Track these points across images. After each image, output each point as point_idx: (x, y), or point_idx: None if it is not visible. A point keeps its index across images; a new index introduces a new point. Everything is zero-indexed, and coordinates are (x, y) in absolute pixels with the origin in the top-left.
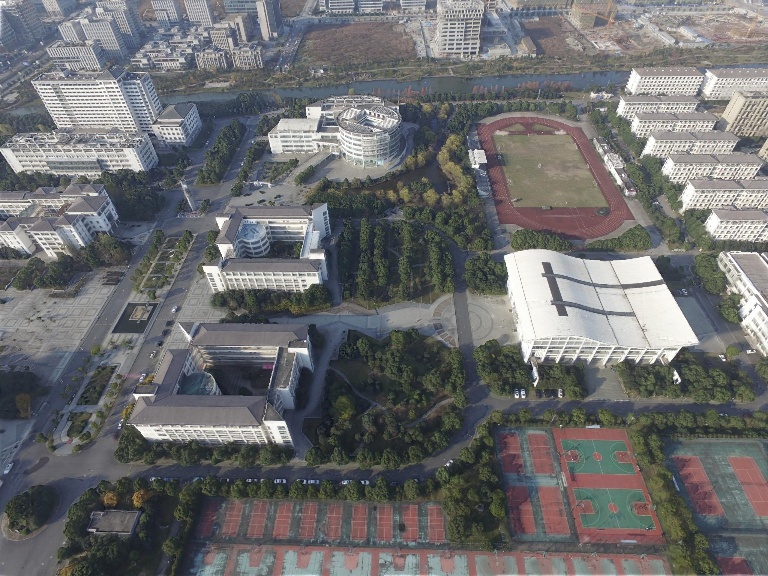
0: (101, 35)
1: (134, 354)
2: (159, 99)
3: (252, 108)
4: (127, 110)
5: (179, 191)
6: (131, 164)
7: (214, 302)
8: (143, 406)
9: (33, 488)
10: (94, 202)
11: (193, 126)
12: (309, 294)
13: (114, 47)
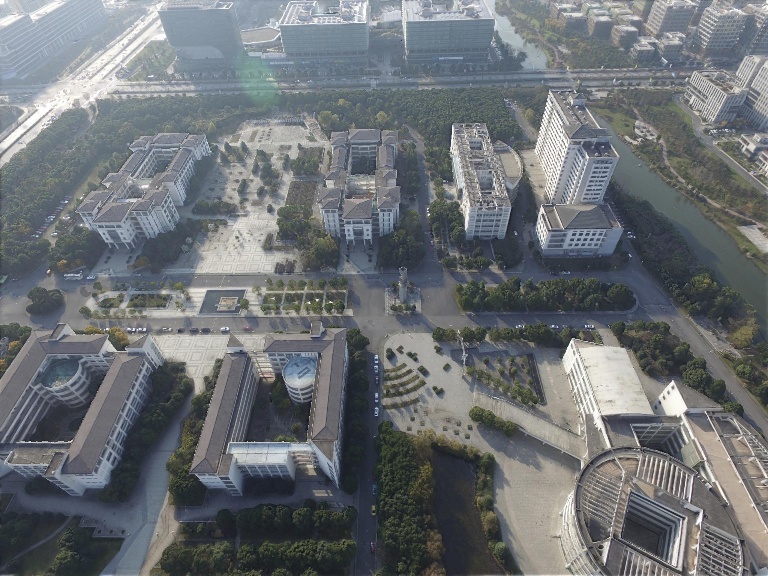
0: (767, 90)
1: (174, 315)
2: (678, 194)
3: (690, 301)
4: (558, 174)
5: (441, 275)
6: (466, 216)
7: (216, 362)
8: (41, 336)
9: (56, 296)
10: (357, 212)
11: (582, 245)
12: (173, 468)
13: (765, 111)
